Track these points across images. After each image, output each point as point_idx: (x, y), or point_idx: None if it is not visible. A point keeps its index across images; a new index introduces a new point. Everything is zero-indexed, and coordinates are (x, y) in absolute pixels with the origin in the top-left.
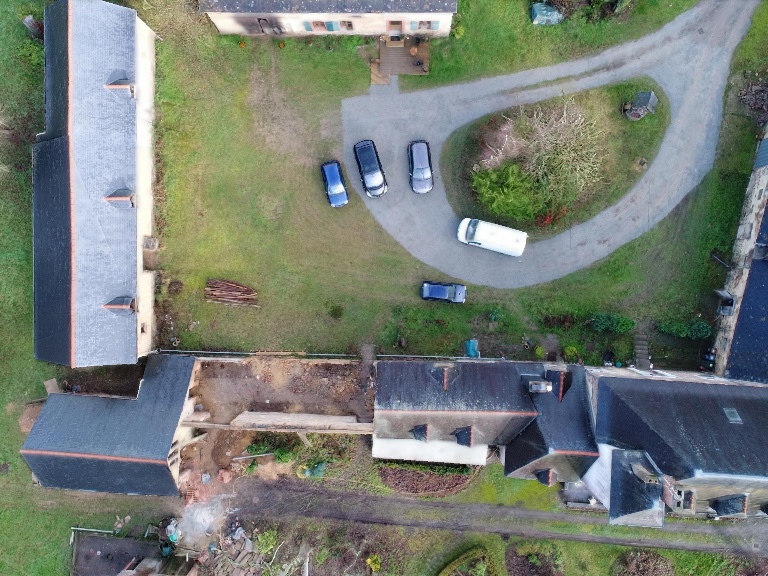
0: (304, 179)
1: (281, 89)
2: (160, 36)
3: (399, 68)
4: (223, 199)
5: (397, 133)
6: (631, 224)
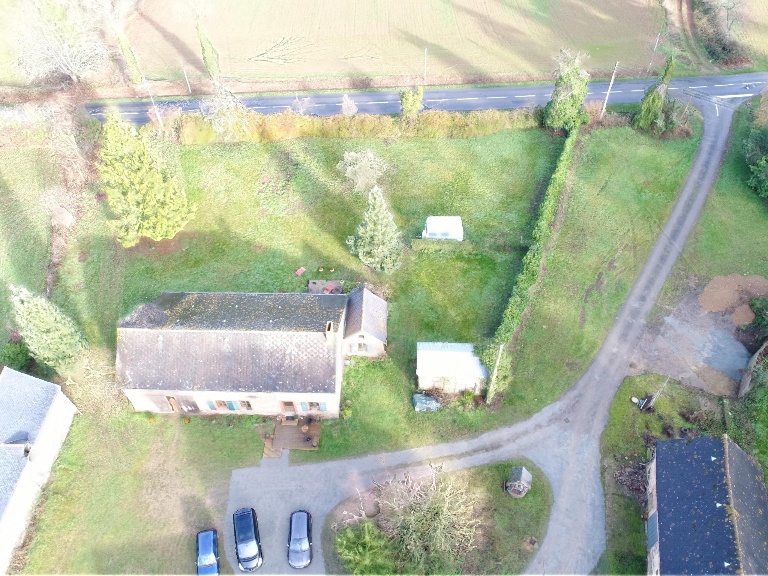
0: (178, 549)
1: (177, 459)
2: (81, 411)
3: (291, 443)
4: (85, 569)
5: (282, 504)
6: None
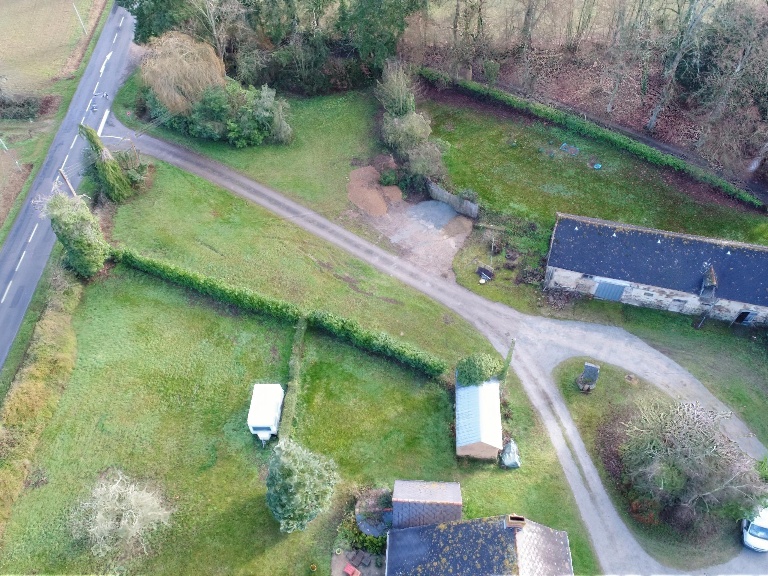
0: None
1: None
2: None
3: None
4: None
5: None
6: (690, 387)
